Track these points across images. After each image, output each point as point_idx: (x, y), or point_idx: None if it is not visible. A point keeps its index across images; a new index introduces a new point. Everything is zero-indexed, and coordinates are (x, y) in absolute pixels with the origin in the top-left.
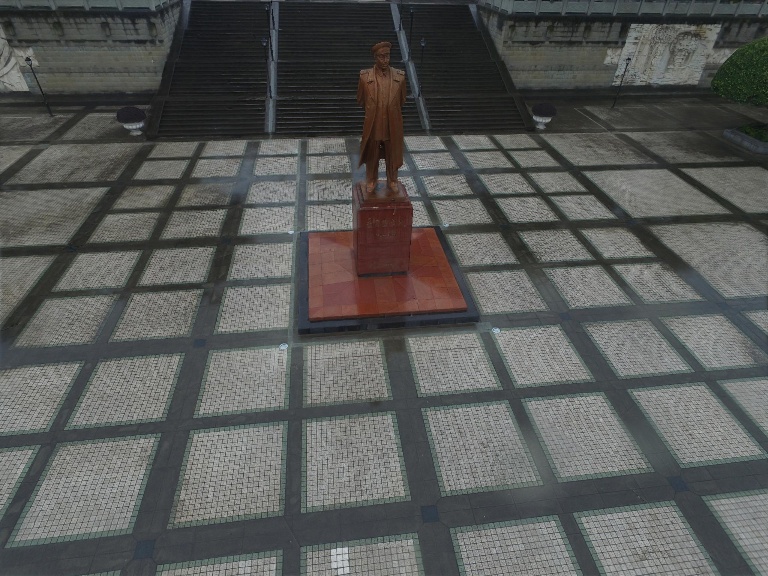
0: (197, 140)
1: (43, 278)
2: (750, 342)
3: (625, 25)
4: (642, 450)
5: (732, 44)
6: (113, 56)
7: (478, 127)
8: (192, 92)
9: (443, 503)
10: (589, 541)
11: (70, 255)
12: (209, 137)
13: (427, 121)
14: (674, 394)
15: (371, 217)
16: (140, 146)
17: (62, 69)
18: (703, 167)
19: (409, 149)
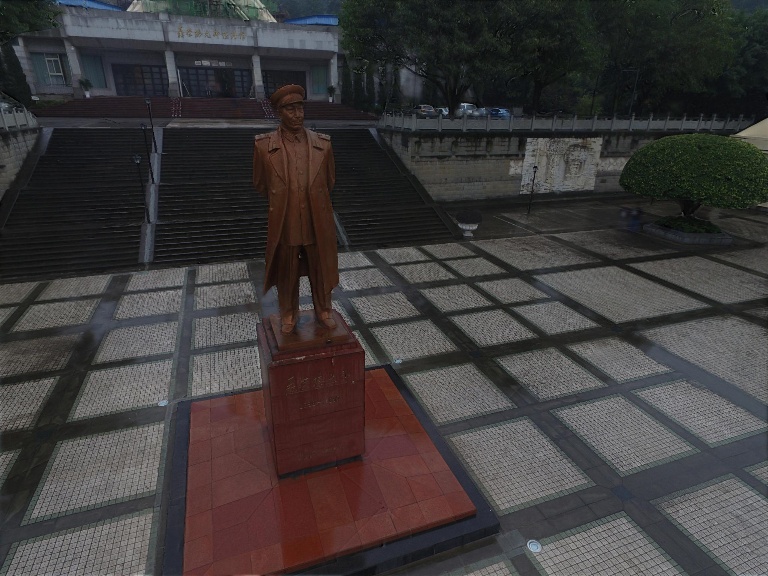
0: (37, 280)
1: None
2: None
3: (522, 139)
4: None
5: (614, 154)
6: None
7: (403, 239)
8: (40, 222)
9: None
10: None
11: None
12: (57, 274)
13: (344, 236)
14: None
15: (294, 375)
16: None
17: None
18: (647, 261)
19: None
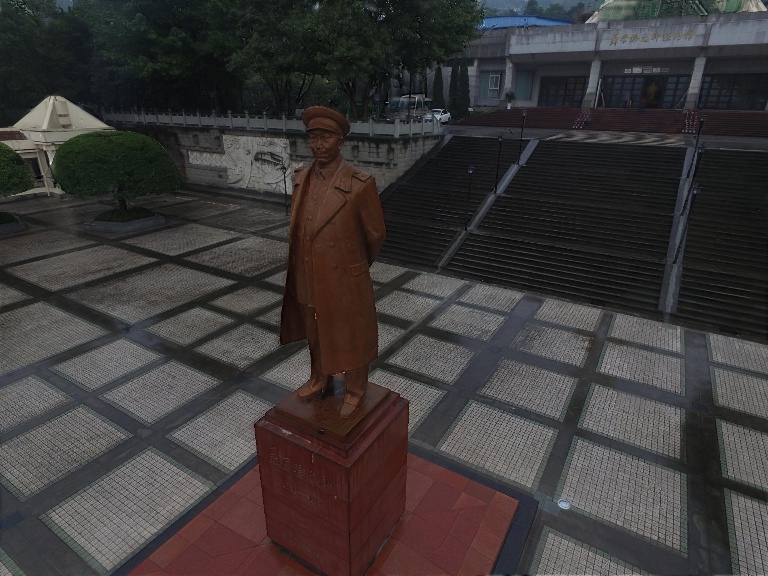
0: None
1: (68, 351)
2: None
3: None
4: None
5: None
6: None
7: None
8: (395, 212)
9: None
10: None
11: (116, 336)
12: (378, 257)
13: (671, 300)
14: None
15: (276, 446)
16: None
17: None
18: None
19: (610, 334)
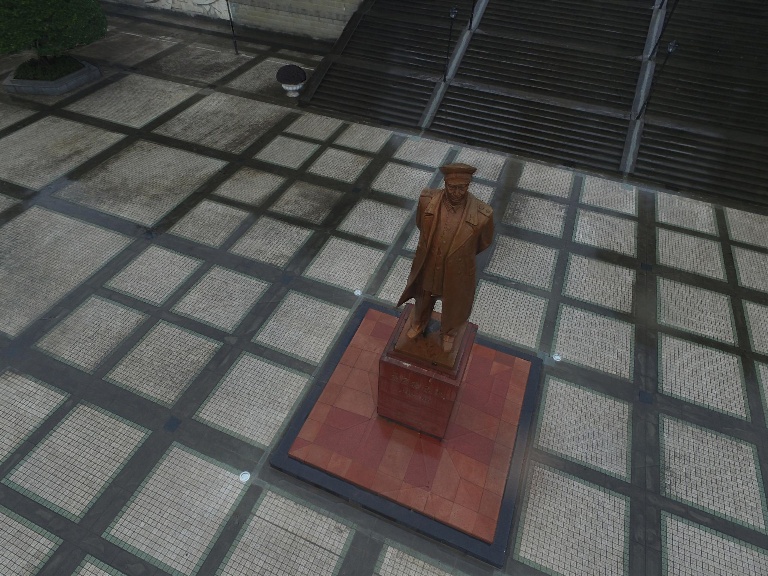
0: (344, 118)
1: (108, 265)
2: None
3: None
4: None
5: None
6: None
7: (707, 188)
8: (365, 55)
9: None
10: None
11: (144, 243)
12: (358, 117)
13: (631, 160)
14: None
15: (398, 372)
16: (287, 113)
17: (262, 3)
18: None
19: (581, 200)
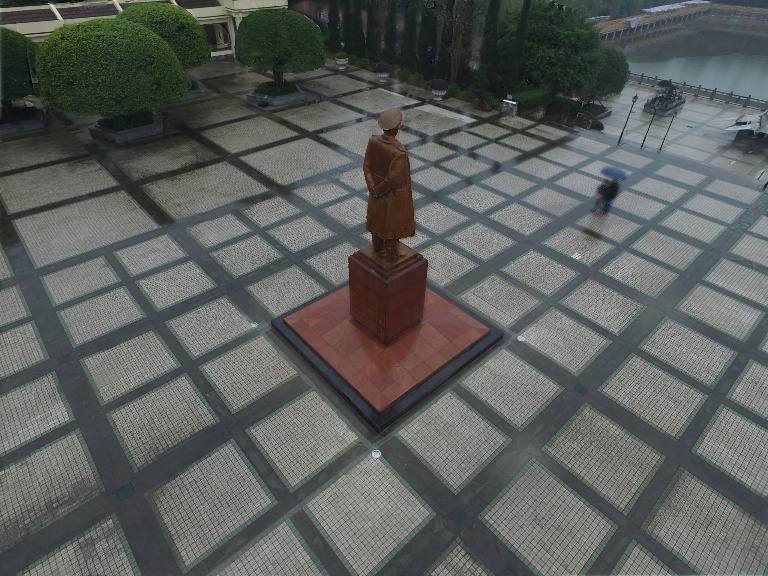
0: None
1: None
2: (313, 184)
3: None
4: None
5: None
6: None
7: None
8: None
9: (521, 241)
10: (487, 209)
11: None
12: None
13: None
14: None
15: None
16: None
17: None
18: (1, 203)
19: None
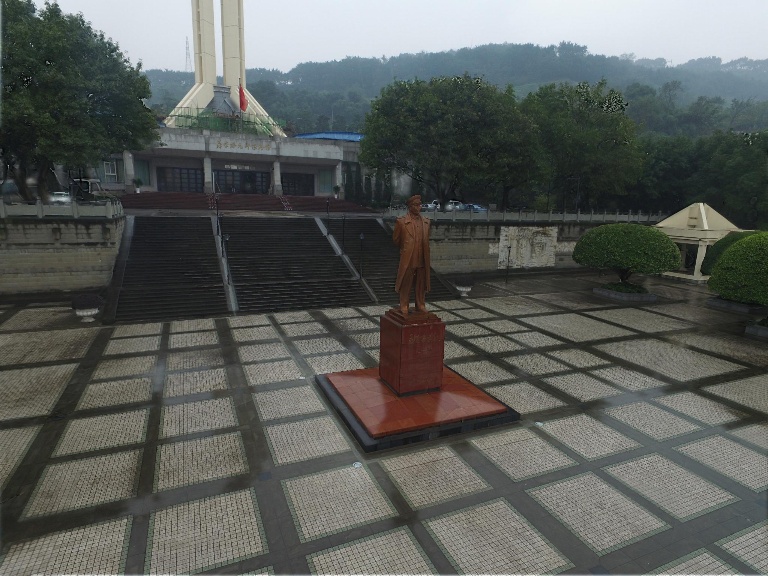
0: (160, 321)
1: (33, 447)
2: (722, 405)
3: (497, 227)
4: (720, 486)
5: (568, 239)
6: (57, 257)
7: None
8: (146, 283)
9: (605, 561)
10: (745, 561)
11: (59, 423)
12: (171, 319)
13: (374, 295)
14: (706, 445)
15: (412, 333)
16: (98, 329)
17: None
18: (597, 310)
19: (369, 314)
